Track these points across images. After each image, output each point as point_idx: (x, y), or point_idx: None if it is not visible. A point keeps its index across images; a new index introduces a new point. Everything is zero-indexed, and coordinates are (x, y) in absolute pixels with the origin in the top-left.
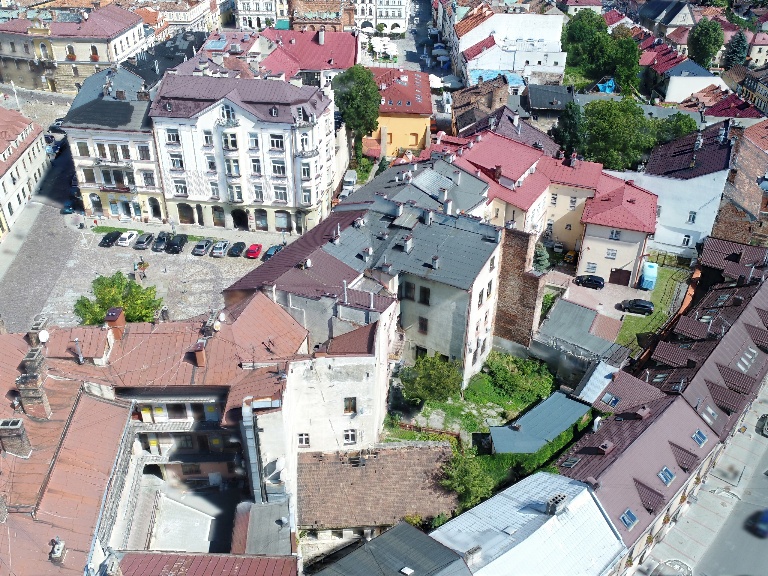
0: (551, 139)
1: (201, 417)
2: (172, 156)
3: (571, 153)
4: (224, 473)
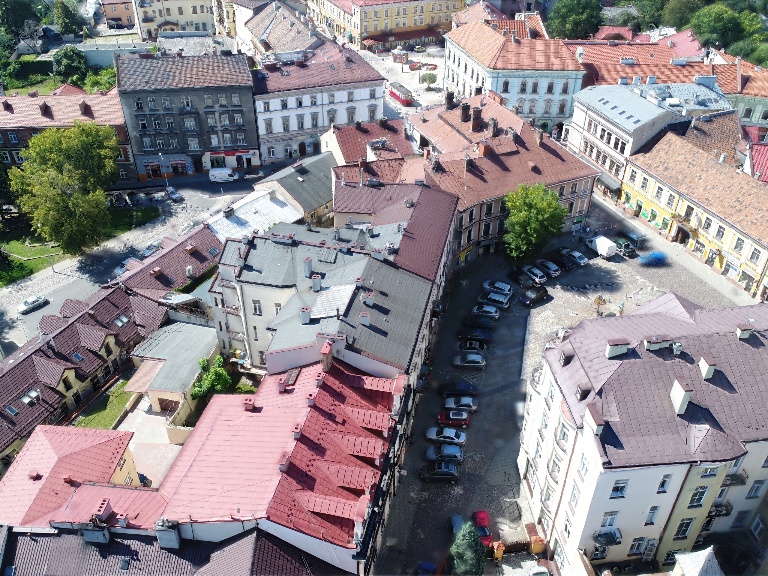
0: None
1: None
2: None
3: None
4: None
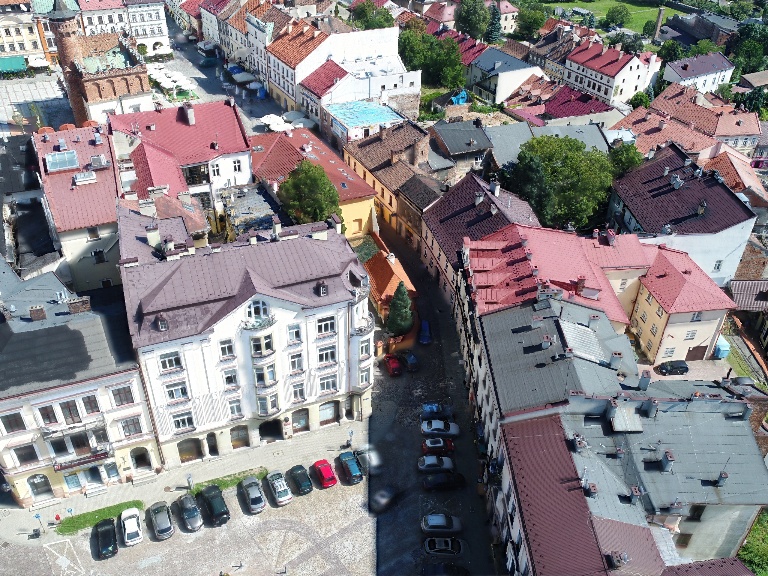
0: (517, 197)
1: None
2: (167, 386)
3: (541, 208)
4: None
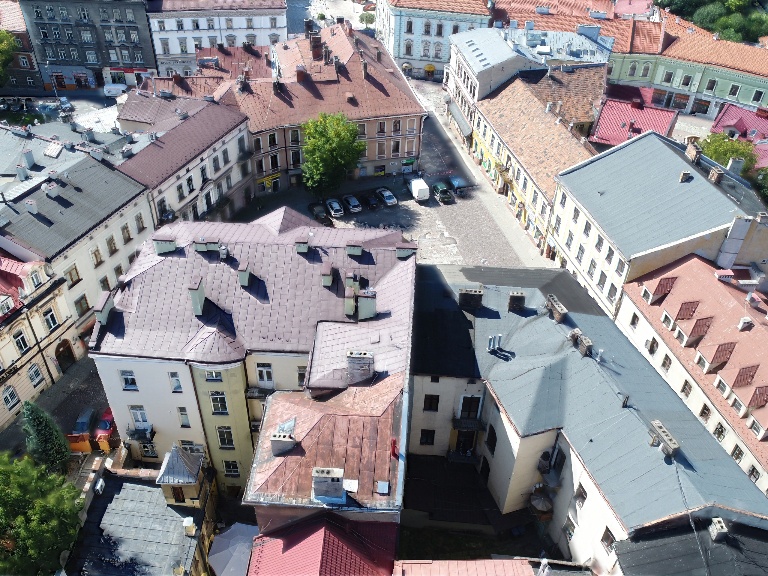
0: None
1: None
2: None
3: None
4: None
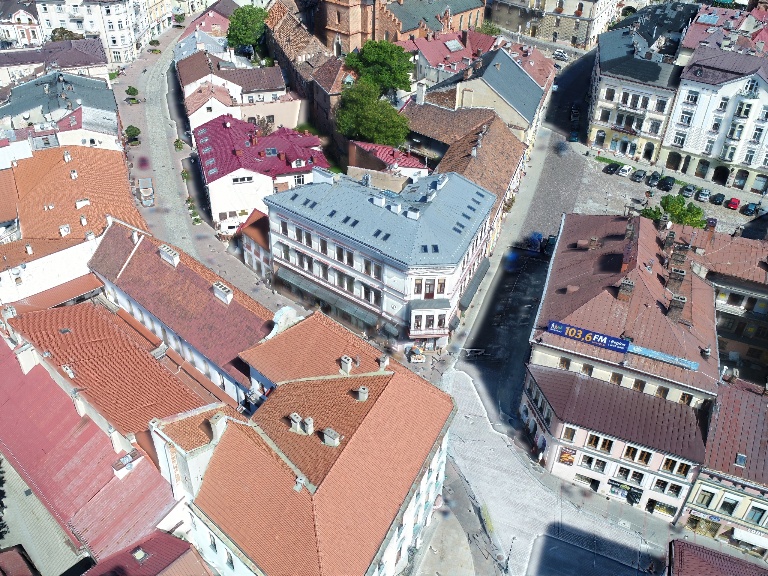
0: None
1: (750, 309)
2: (683, 113)
3: None
4: (742, 354)
